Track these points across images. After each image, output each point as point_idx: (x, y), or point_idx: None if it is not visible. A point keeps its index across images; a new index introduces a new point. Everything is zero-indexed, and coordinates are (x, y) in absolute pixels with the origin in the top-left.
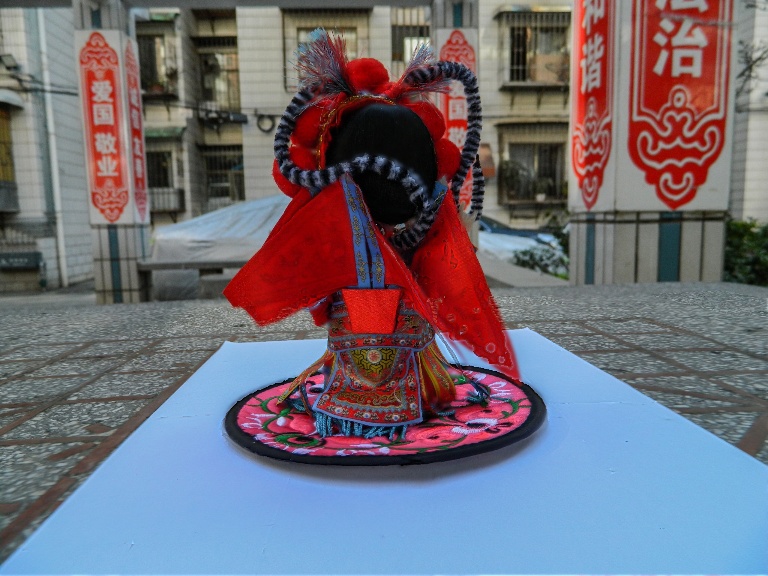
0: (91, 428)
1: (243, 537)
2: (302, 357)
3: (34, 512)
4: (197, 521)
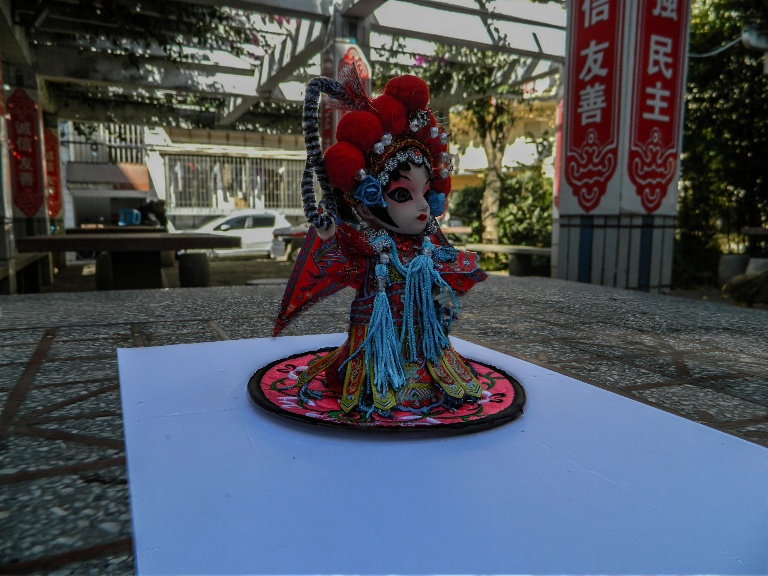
0: (577, 366)
1: None
2: (634, 460)
3: None
4: None
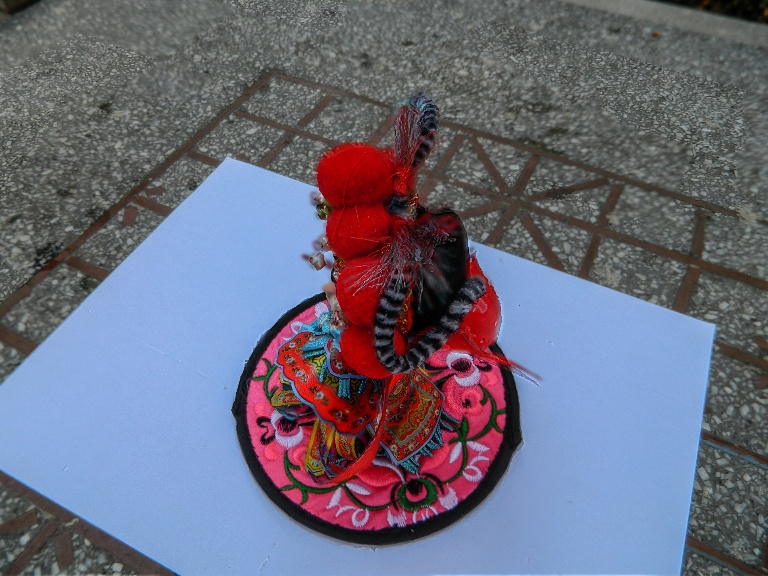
0: None
1: None
2: (137, 384)
3: None
4: None
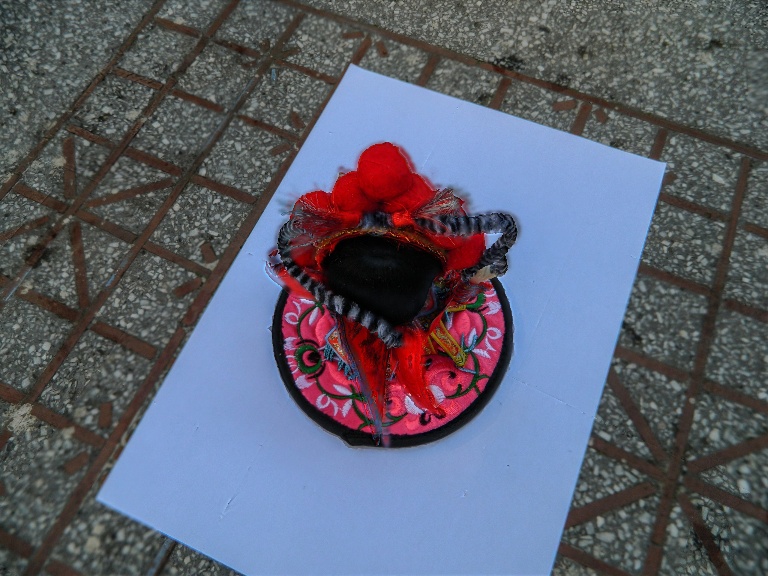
0: (204, 251)
1: (245, 450)
2: None
3: (161, 365)
4: (230, 422)
